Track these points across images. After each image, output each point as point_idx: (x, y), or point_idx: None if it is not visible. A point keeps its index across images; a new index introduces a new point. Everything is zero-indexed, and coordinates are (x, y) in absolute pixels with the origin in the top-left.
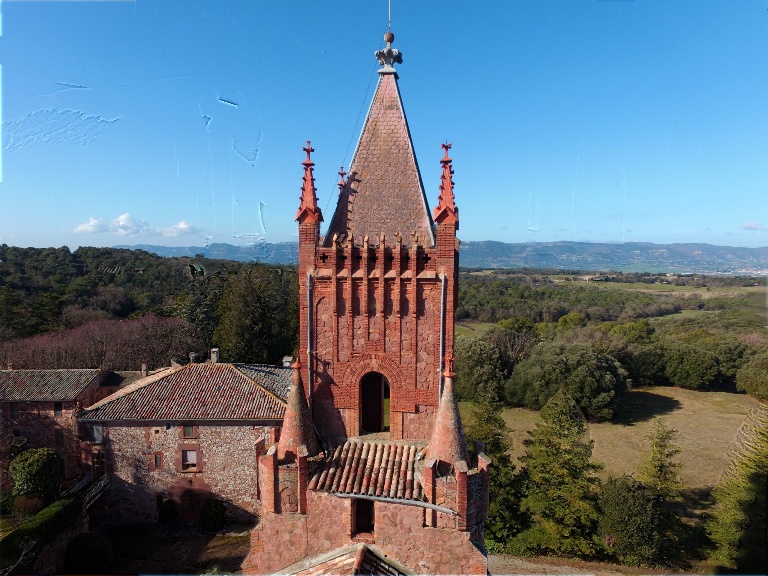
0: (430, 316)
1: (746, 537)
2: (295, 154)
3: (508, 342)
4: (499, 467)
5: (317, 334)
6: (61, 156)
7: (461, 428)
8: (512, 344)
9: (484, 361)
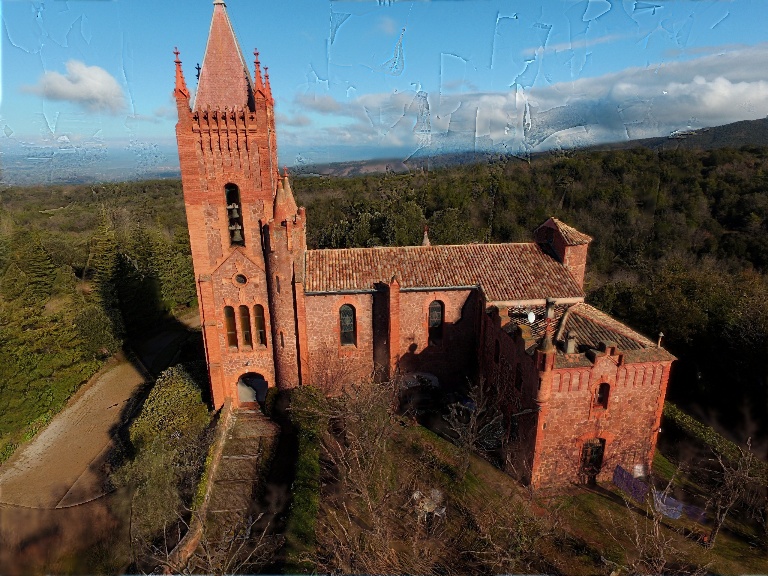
0: None
1: (124, 317)
2: None
3: None
4: None
5: None
6: None
7: None
8: None
9: None
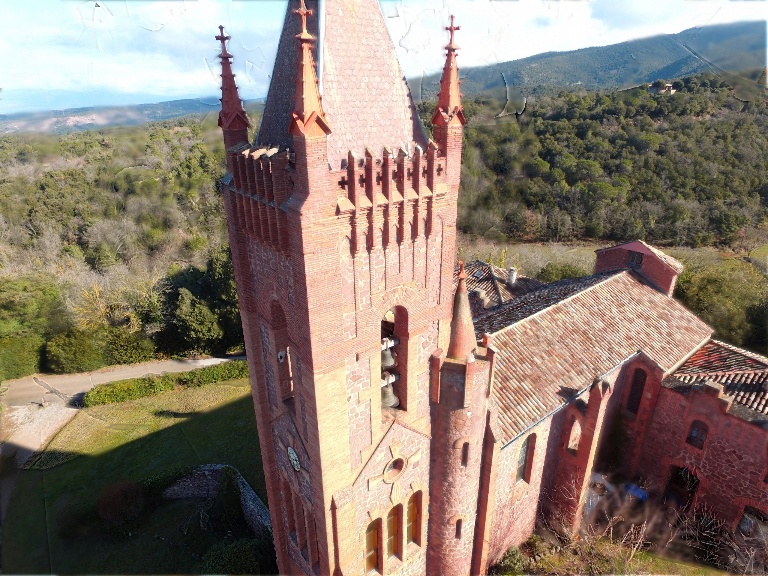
0: None
1: None
2: None
3: None
4: None
5: None
6: None
7: None
8: None
9: None
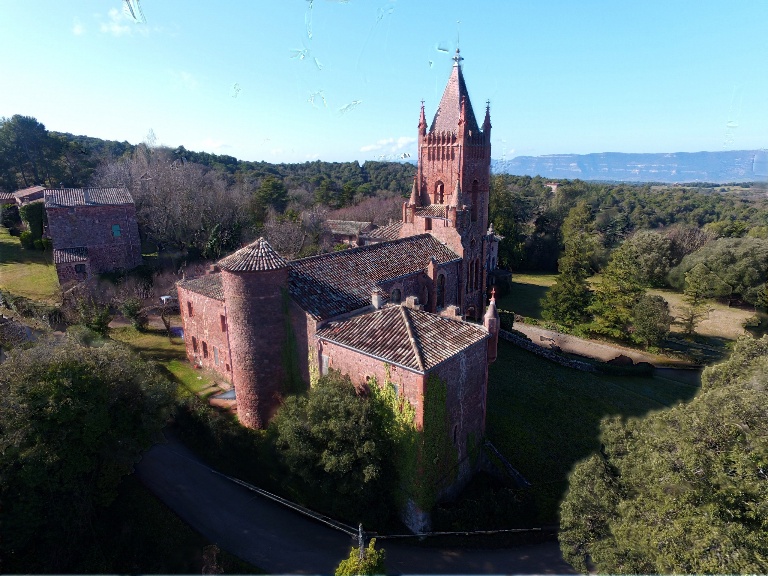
0: (456, 160)
1: None
2: (494, 78)
3: (687, 236)
4: (575, 285)
5: (423, 168)
6: (353, 113)
7: (460, 197)
8: (691, 238)
9: (652, 249)
